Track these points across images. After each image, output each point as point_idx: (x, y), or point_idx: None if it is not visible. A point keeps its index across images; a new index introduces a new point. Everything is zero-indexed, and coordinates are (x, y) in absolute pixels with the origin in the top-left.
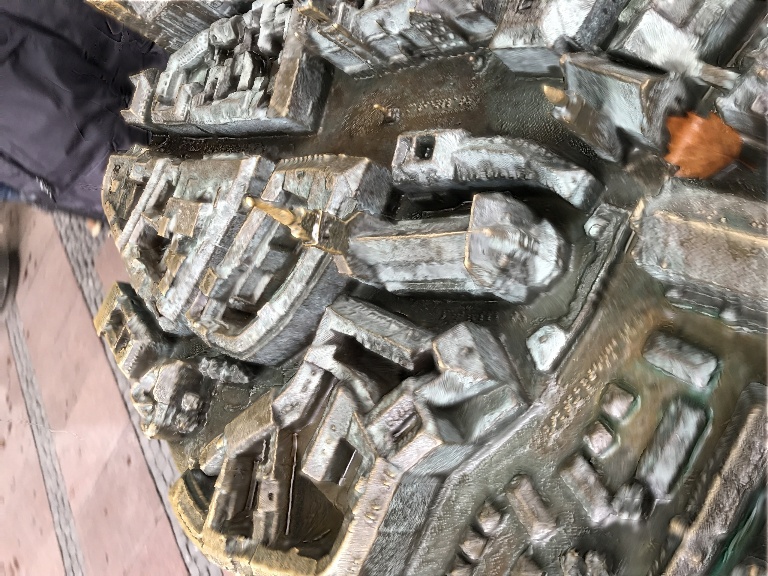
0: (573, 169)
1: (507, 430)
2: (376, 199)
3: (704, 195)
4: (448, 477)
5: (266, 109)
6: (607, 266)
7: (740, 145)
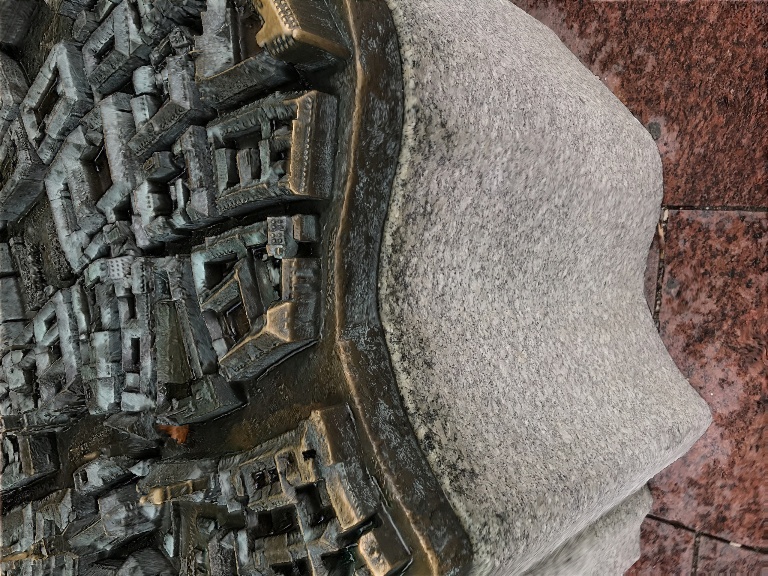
0: (137, 463)
1: None
2: (87, 503)
3: (161, 467)
4: None
5: None
6: None
7: None
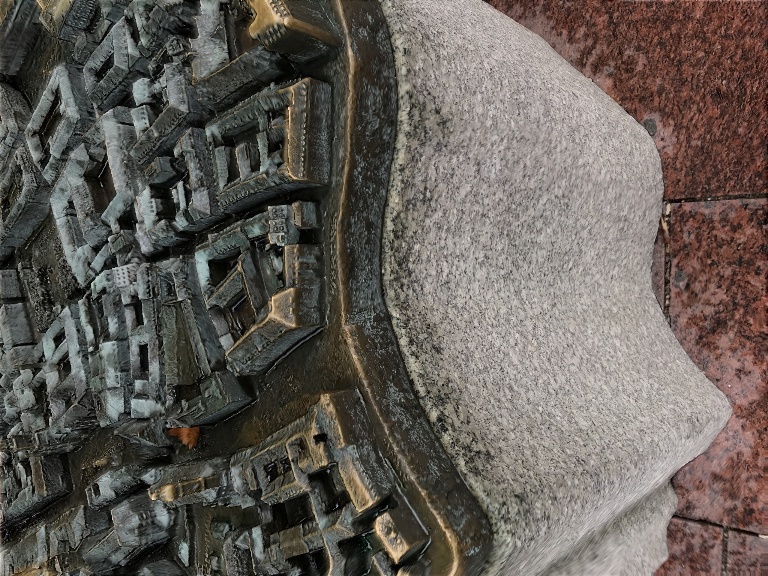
0: (149, 471)
1: None
2: (101, 520)
3: None
4: None
5: None
6: None
7: (199, 427)
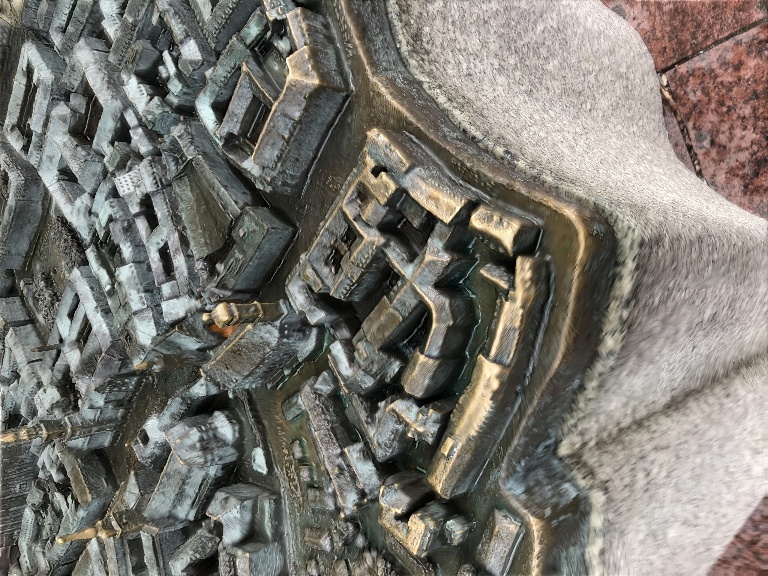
0: (198, 381)
1: (285, 518)
2: None
3: None
4: (289, 574)
5: (81, 508)
6: (247, 402)
7: None
